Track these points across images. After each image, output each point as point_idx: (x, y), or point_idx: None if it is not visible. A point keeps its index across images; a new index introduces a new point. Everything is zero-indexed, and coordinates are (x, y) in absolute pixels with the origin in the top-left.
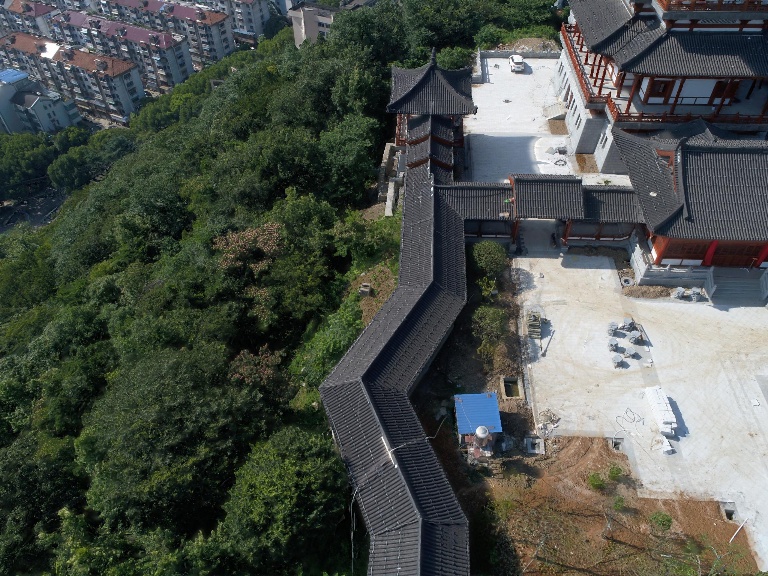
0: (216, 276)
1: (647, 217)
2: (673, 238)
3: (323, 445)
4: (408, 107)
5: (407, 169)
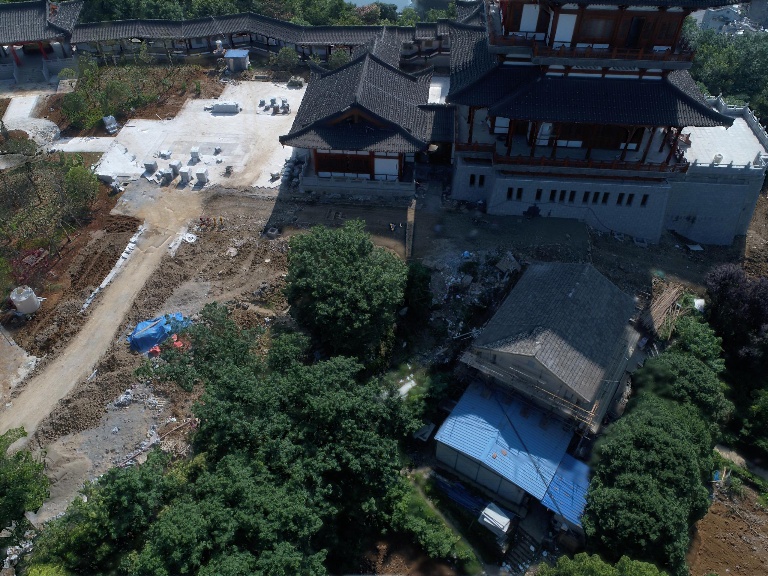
0: (353, 13)
1: None
2: None
3: (224, 10)
4: (461, 8)
5: None
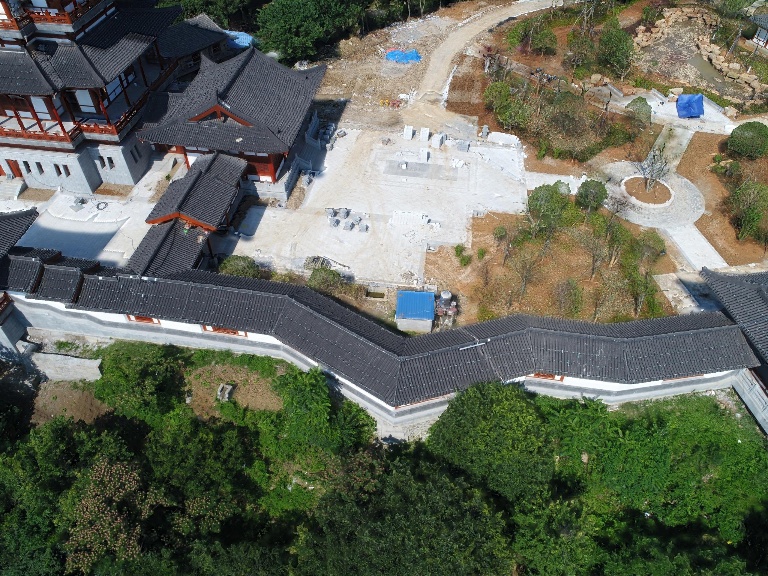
0: (140, 572)
1: (264, 150)
2: (272, 155)
3: None
4: None
5: (74, 305)
